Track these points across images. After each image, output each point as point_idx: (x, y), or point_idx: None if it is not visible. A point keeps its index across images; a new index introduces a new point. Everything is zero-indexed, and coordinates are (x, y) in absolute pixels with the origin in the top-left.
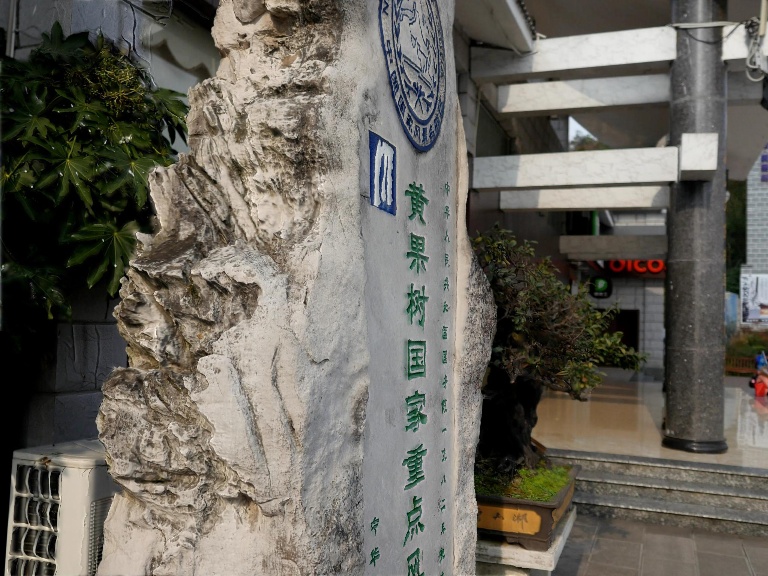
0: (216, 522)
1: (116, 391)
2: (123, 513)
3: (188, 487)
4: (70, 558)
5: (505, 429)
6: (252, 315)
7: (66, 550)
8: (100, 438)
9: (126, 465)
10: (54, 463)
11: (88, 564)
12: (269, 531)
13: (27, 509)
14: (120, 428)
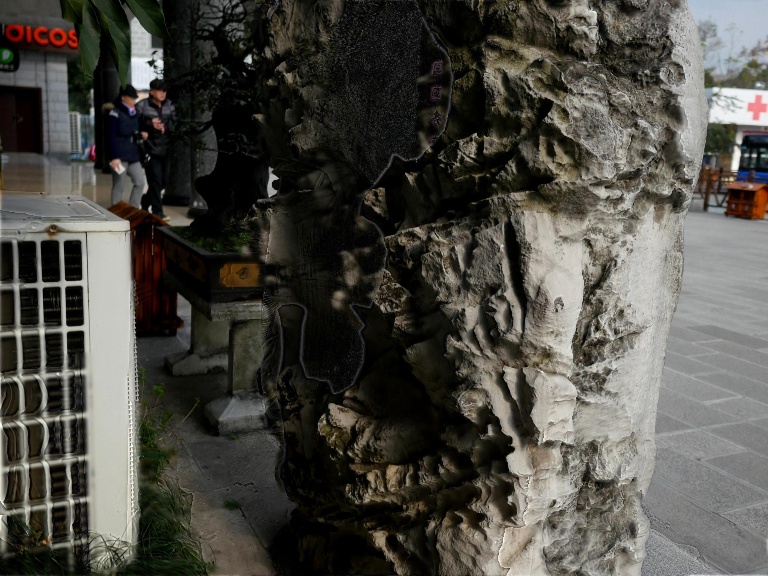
0: (638, 225)
1: (583, 84)
2: (550, 229)
3: (629, 191)
4: (117, 354)
5: (261, 189)
6: (682, 8)
7: (109, 345)
8: (580, 139)
9: (613, 167)
10: (62, 229)
11: (135, 358)
12: (674, 227)
13: (19, 302)
14: (598, 127)
